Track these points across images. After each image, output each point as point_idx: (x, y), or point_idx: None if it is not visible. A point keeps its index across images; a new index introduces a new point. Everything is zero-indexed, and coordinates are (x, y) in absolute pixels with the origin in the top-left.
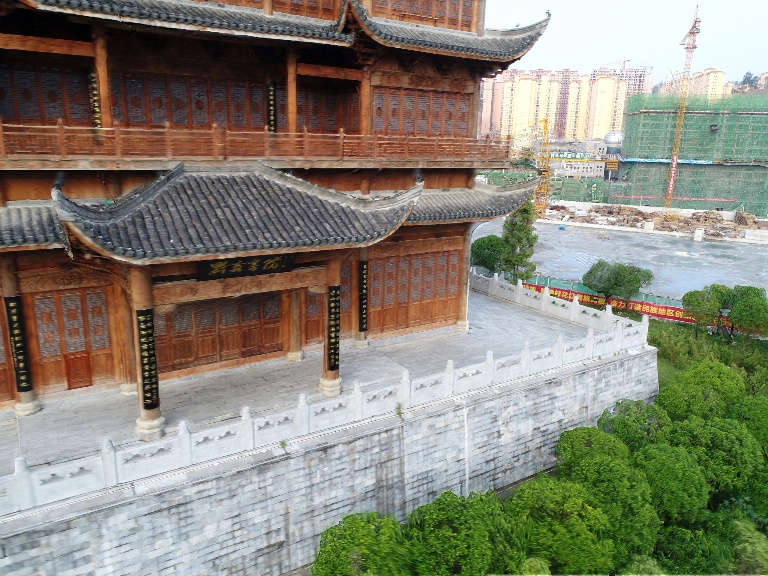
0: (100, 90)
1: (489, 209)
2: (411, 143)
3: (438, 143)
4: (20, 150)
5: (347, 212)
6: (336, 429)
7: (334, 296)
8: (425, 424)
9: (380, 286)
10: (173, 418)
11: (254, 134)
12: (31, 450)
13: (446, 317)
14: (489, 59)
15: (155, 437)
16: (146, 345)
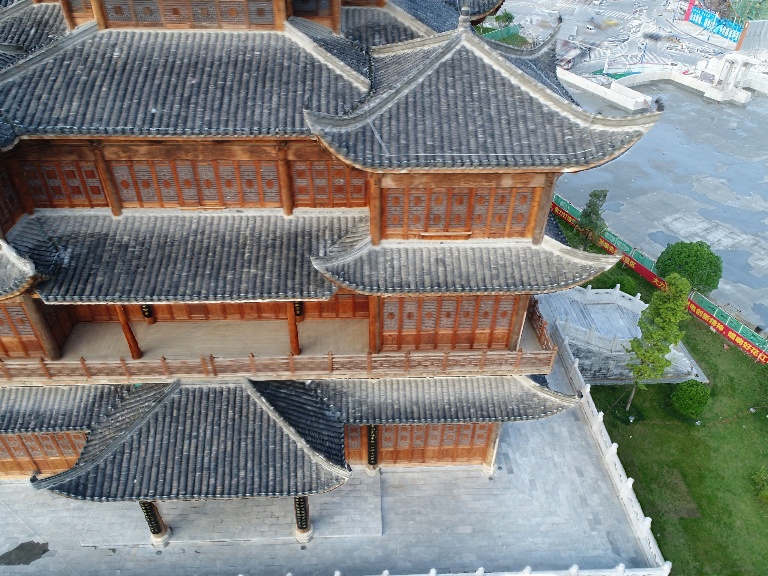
0: (119, 318)
1: (512, 410)
2: (413, 359)
3: (448, 358)
4: (59, 374)
5: (298, 455)
6: None
7: None
8: None
9: (393, 435)
10: (180, 529)
11: (240, 360)
12: (90, 531)
13: (470, 459)
14: (521, 293)
15: (160, 546)
16: (144, 507)
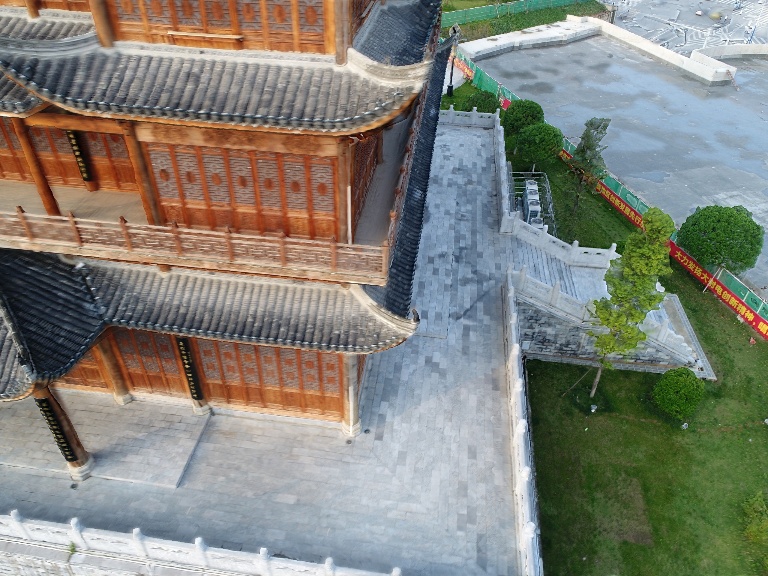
0: None
1: (338, 335)
2: (183, 237)
3: (231, 241)
4: None
5: (3, 345)
6: (2, 537)
7: (41, 406)
8: (100, 572)
9: (216, 362)
10: None
11: None
12: None
13: (324, 412)
14: (301, 131)
15: None
16: None
